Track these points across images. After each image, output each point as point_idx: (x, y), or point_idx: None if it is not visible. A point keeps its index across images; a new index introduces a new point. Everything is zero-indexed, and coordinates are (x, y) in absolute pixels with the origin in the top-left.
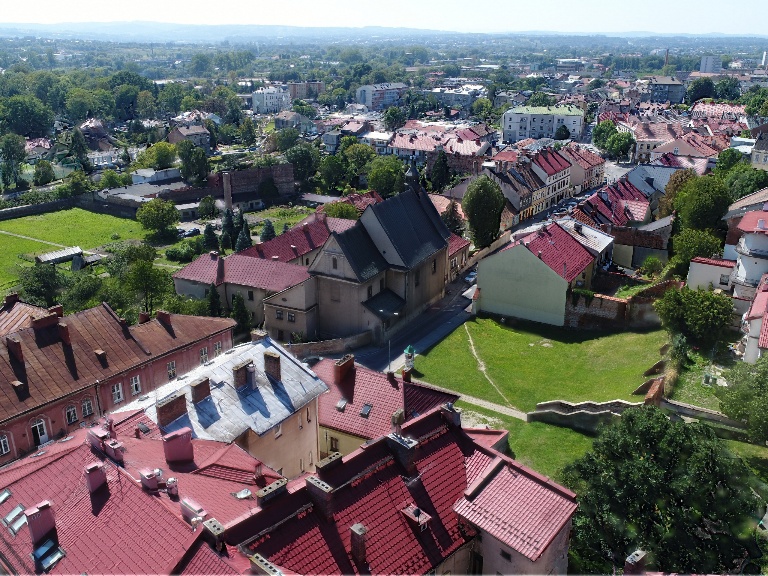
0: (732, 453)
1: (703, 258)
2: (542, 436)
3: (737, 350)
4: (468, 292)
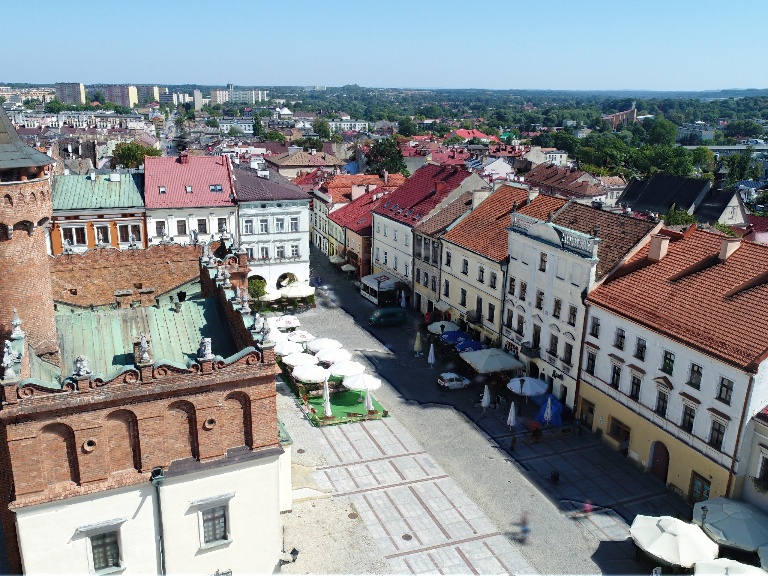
0: None
1: None
2: None
3: None
4: None
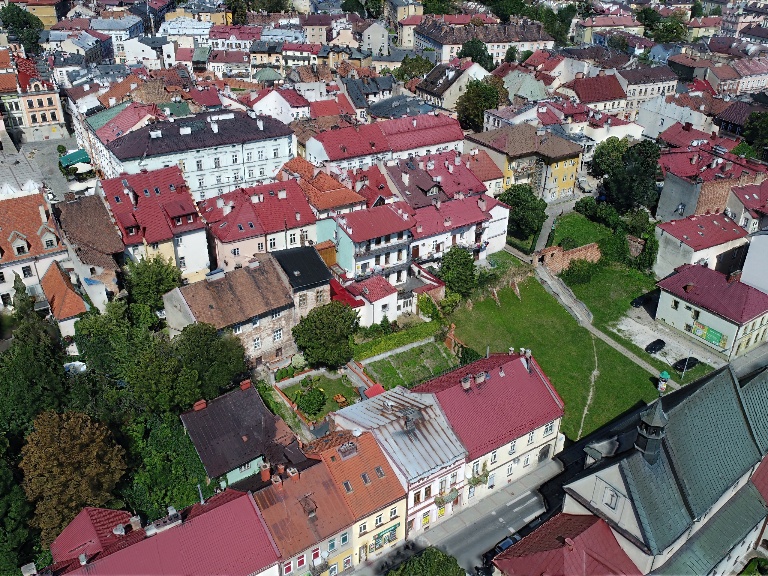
0: (537, 237)
1: (374, 296)
2: (594, 305)
3: (485, 242)
4: (535, 513)
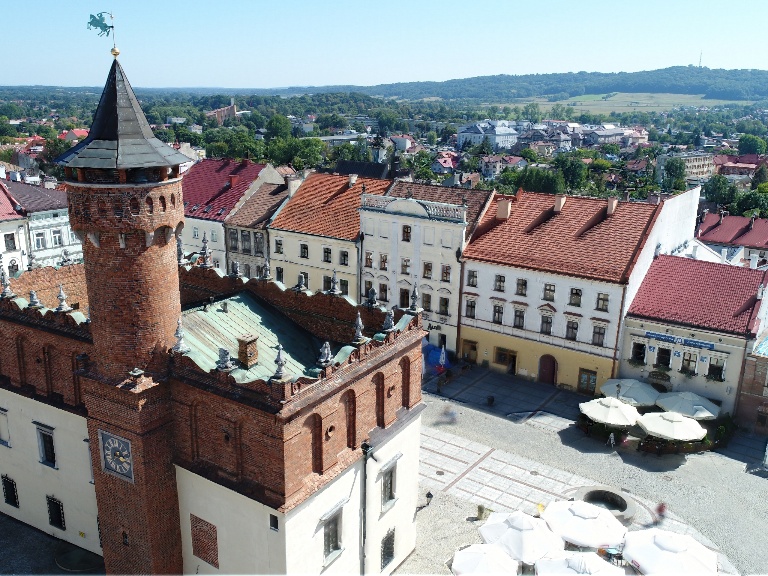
0: None
1: None
2: None
3: None
4: None
